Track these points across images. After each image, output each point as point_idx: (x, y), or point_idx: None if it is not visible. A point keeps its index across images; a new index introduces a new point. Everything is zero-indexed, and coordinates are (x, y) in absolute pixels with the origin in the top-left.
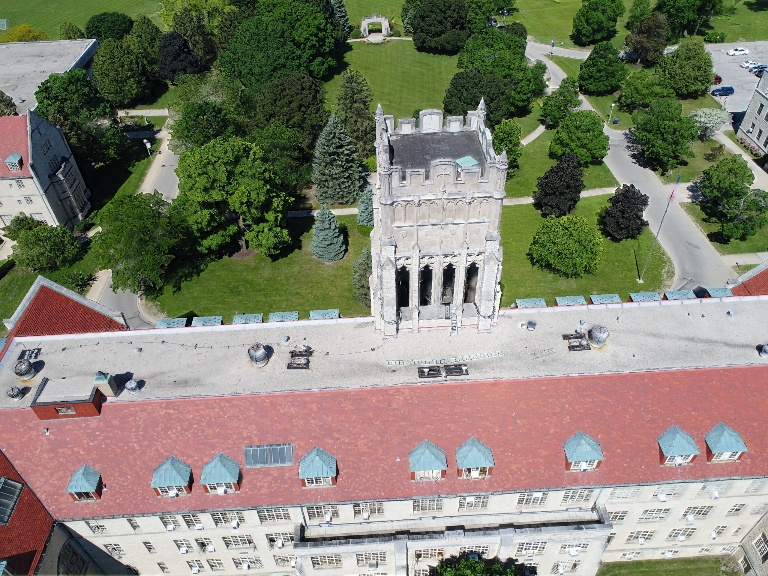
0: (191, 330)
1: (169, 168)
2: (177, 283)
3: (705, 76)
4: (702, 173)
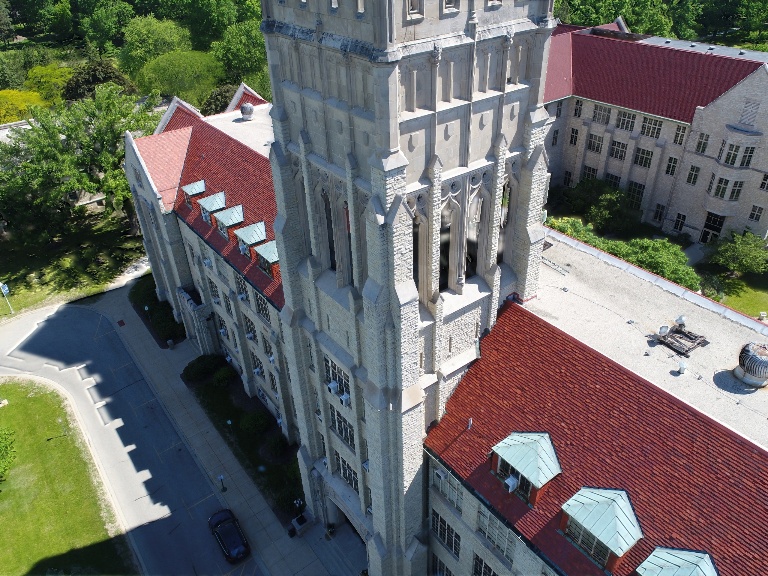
0: None
1: None
2: None
3: None
4: None
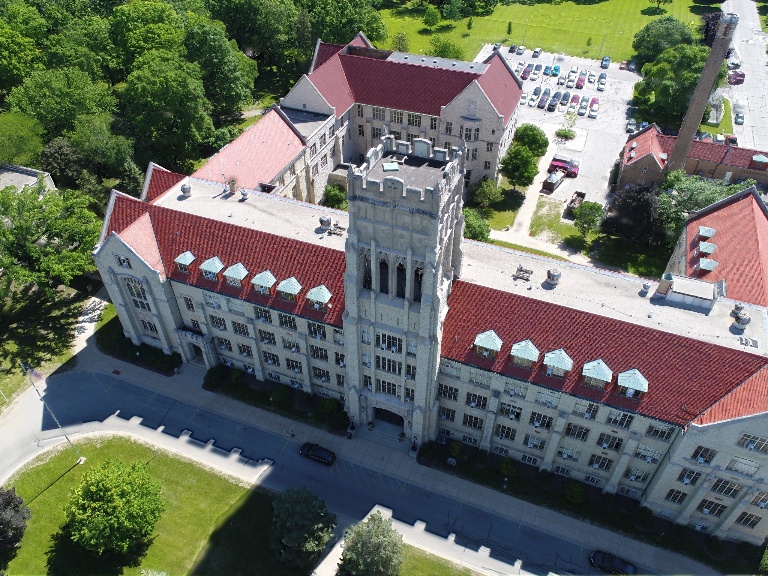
0: None
1: None
2: None
3: None
4: None
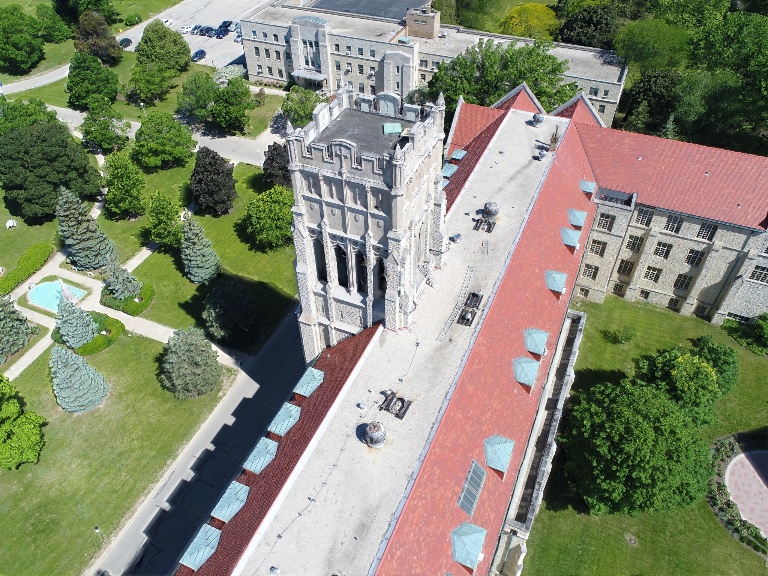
0: (282, 498)
1: None
2: None
3: (183, 48)
4: (267, 117)
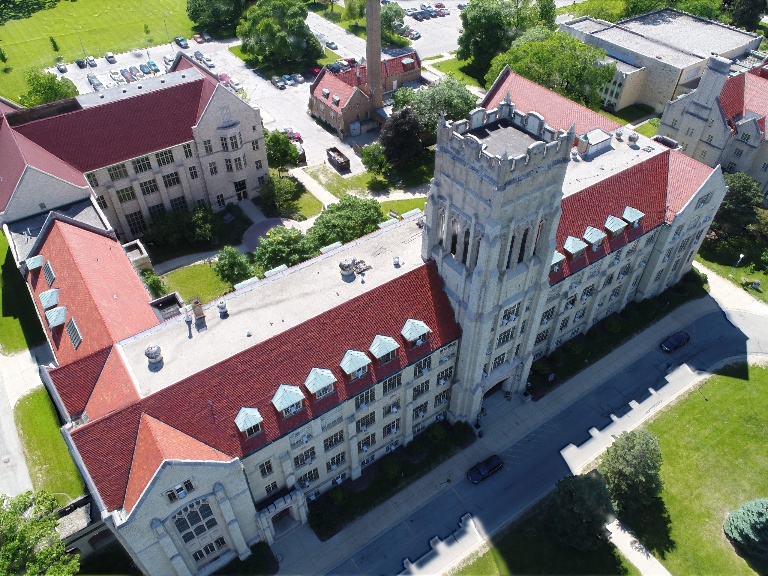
0: None
1: None
2: None
3: None
4: None
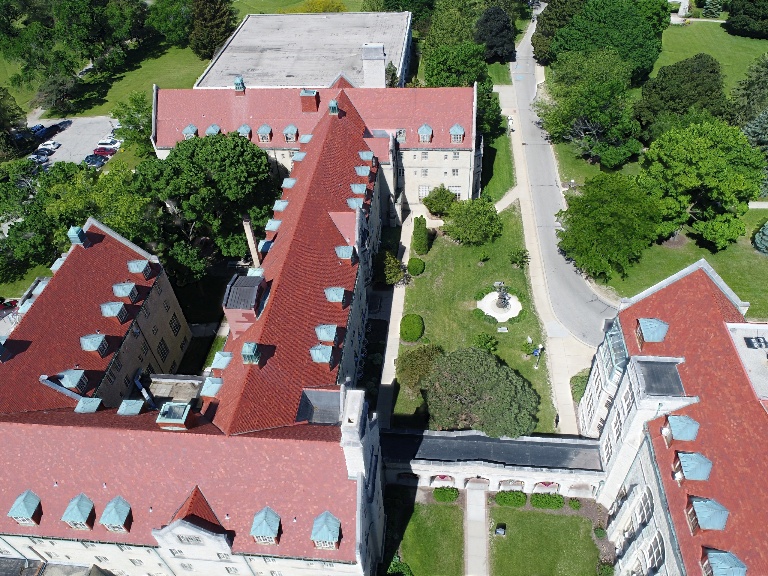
0: None
1: (532, 147)
2: (620, 268)
3: None
4: None
